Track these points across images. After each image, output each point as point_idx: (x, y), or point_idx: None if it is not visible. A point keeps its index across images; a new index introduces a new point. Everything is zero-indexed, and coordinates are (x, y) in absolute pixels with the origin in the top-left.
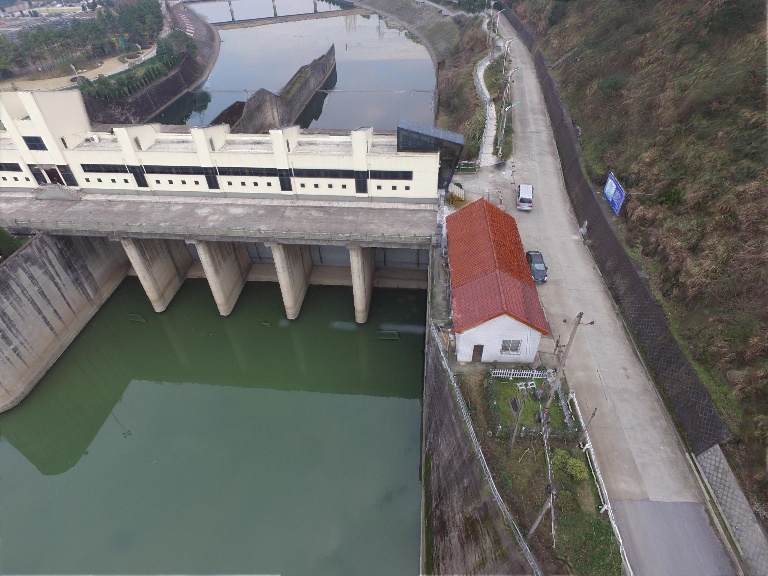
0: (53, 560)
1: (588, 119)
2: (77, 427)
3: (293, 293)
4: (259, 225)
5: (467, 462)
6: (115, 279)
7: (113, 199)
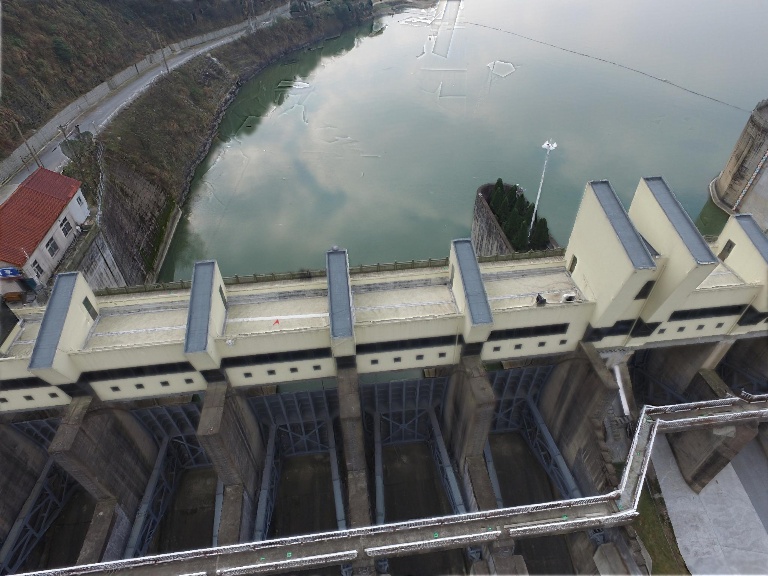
0: None
1: None
2: None
3: None
4: None
5: None
6: None
7: None
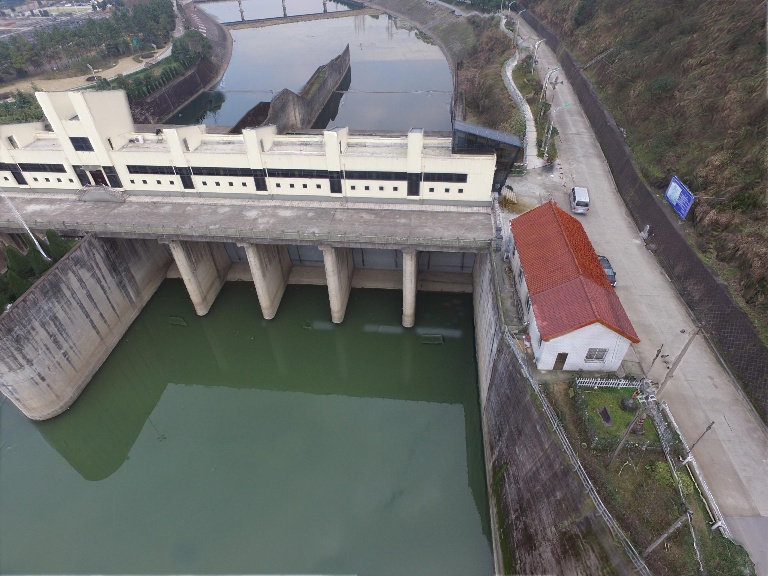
0: (117, 571)
1: (634, 121)
2: (120, 432)
3: (340, 297)
4: (311, 228)
5: (560, 474)
6: (155, 282)
7: (158, 201)
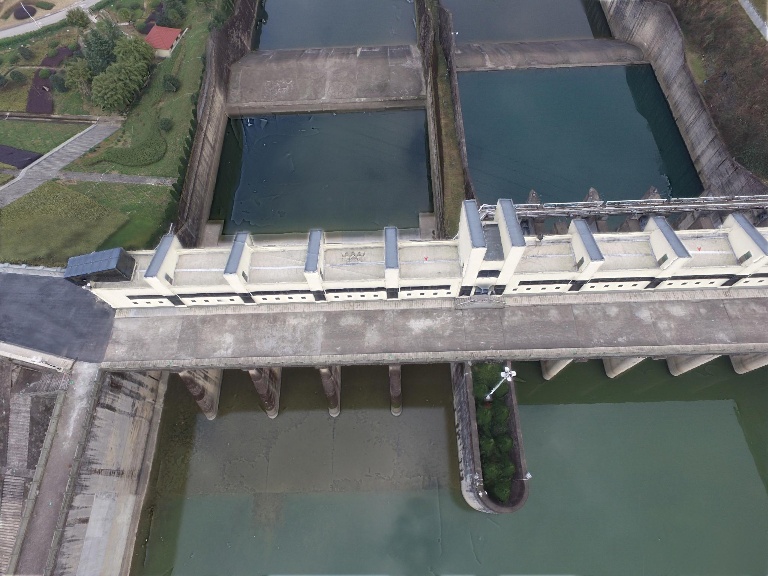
0: None
1: None
2: None
3: None
4: (718, 333)
5: None
6: None
7: (538, 304)
